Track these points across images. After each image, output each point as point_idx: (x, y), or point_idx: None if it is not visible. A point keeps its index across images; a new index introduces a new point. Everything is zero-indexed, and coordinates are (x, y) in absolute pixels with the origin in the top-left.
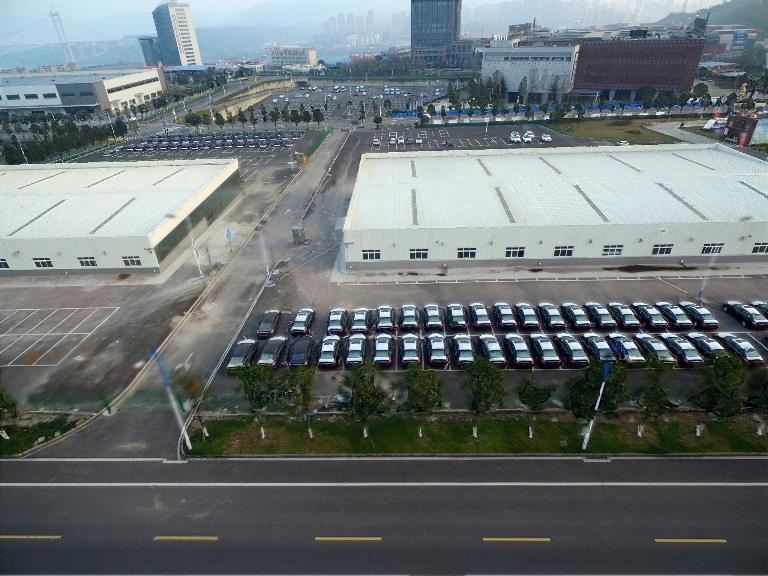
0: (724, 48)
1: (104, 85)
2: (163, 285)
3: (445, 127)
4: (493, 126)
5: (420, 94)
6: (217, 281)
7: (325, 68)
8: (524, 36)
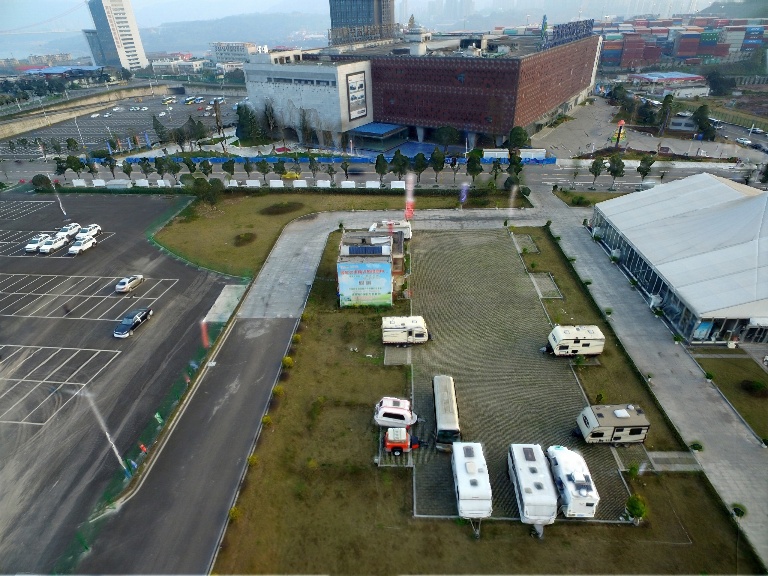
0: (727, 49)
1: None
2: None
3: (70, 193)
4: (133, 195)
5: None
6: None
7: None
8: (380, 41)
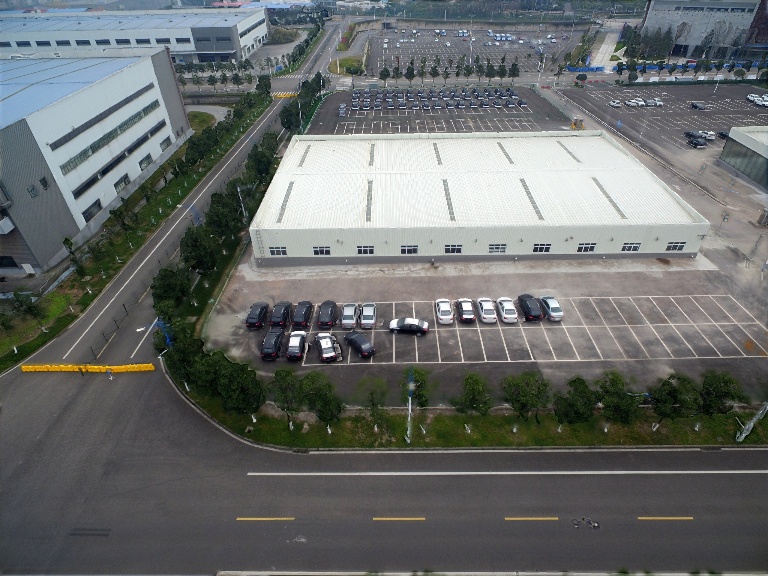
0: None
1: (237, 29)
2: (724, 271)
3: (652, 85)
4: (702, 85)
5: (538, 41)
6: (762, 266)
7: (389, 6)
8: None
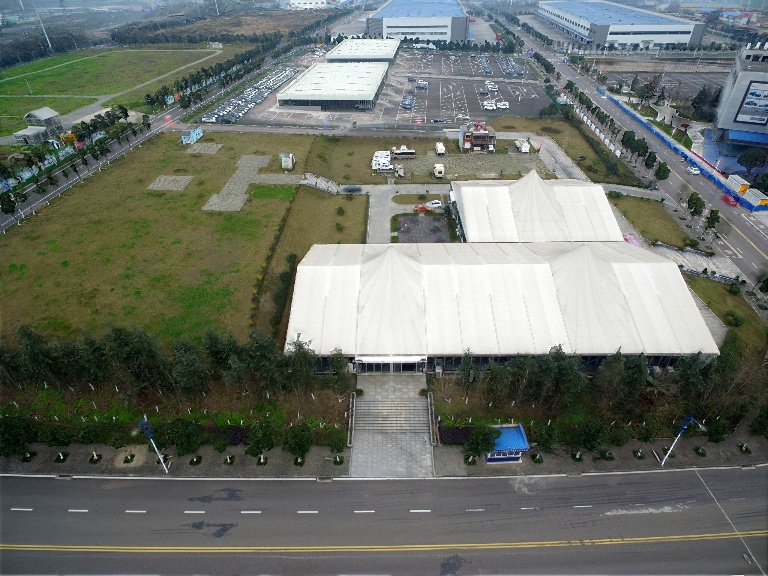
0: None
1: (609, 28)
2: None
3: None
4: None
5: None
6: None
7: None
8: None
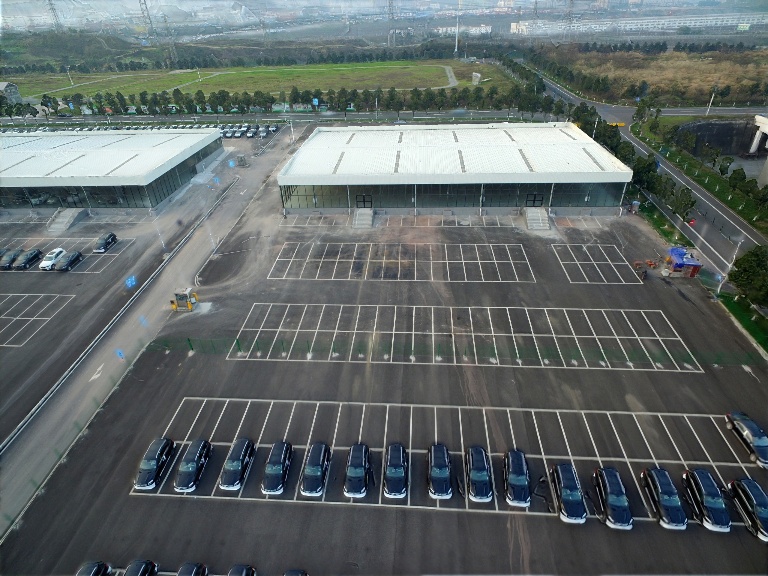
0: None
1: None
2: None
3: None
4: None
5: None
6: None
7: None
8: None
